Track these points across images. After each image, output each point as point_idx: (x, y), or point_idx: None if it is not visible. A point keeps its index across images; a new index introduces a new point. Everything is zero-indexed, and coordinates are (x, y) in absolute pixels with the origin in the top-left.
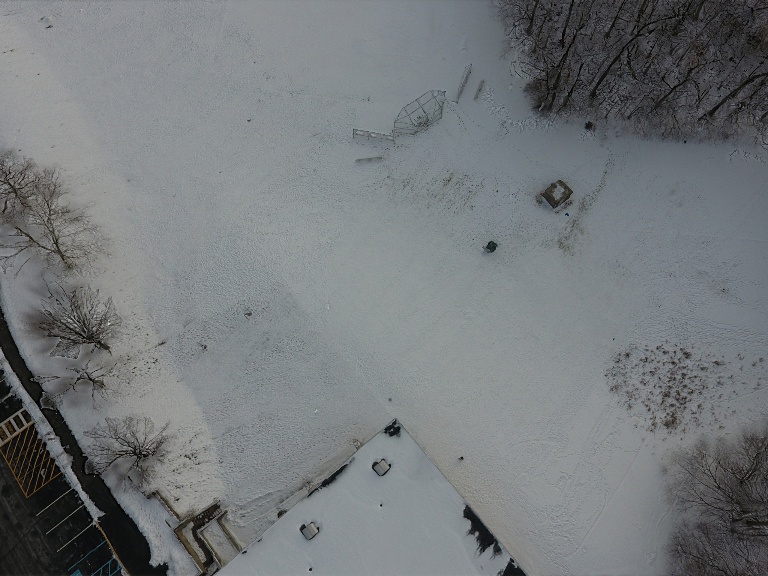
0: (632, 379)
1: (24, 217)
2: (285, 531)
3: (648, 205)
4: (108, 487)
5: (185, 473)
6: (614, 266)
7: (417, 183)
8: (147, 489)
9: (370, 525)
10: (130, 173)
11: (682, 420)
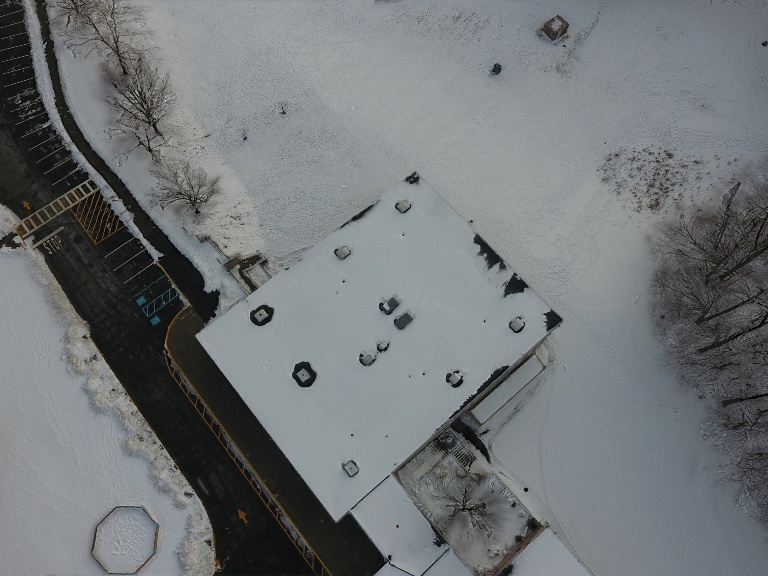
0: (621, 173)
1: (86, 28)
2: (321, 253)
3: (637, 38)
4: (166, 235)
5: (231, 229)
6: (606, 86)
7: (430, 19)
8: (200, 233)
9: (394, 249)
10: (174, 8)
11: (665, 204)
